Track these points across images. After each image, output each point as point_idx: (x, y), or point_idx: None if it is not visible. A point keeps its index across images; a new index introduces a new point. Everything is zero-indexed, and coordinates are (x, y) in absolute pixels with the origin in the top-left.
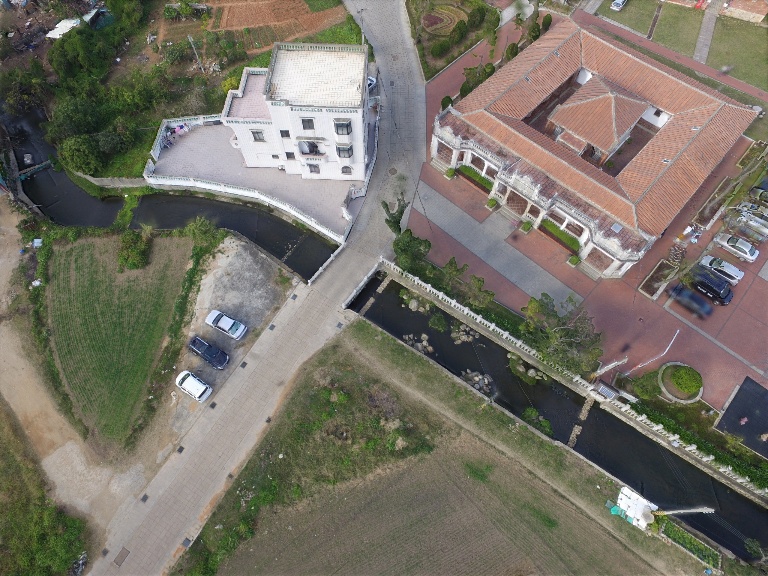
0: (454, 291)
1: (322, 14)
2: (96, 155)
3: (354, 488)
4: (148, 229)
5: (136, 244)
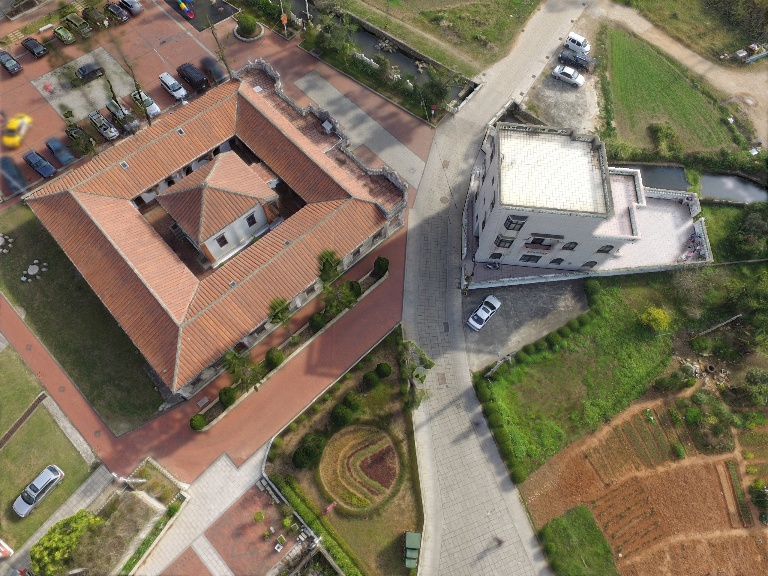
0: (396, 92)
1: (567, 500)
2: (757, 213)
3: (467, 2)
4: (663, 148)
5: (667, 140)
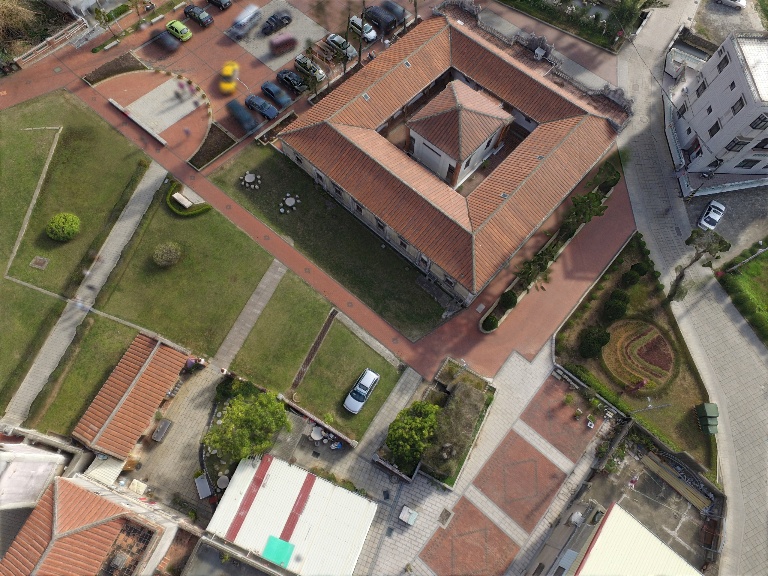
0: (571, 24)
1: None
2: None
3: None
4: None
5: None
